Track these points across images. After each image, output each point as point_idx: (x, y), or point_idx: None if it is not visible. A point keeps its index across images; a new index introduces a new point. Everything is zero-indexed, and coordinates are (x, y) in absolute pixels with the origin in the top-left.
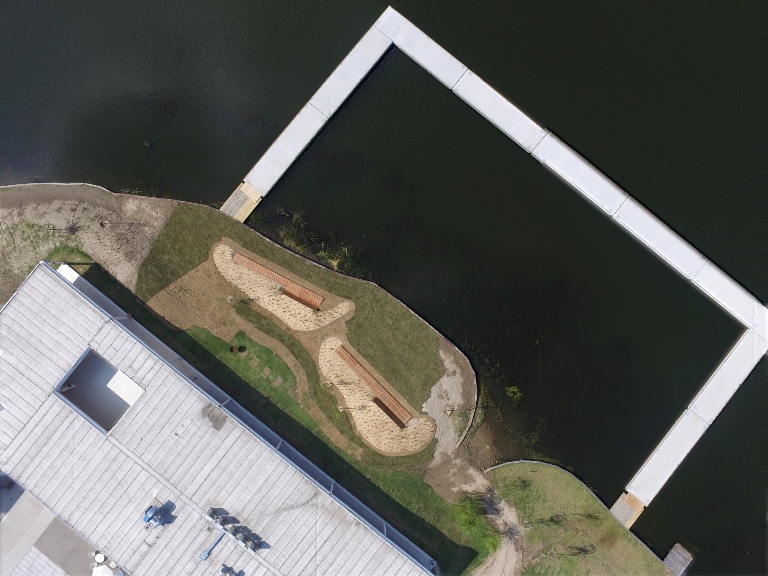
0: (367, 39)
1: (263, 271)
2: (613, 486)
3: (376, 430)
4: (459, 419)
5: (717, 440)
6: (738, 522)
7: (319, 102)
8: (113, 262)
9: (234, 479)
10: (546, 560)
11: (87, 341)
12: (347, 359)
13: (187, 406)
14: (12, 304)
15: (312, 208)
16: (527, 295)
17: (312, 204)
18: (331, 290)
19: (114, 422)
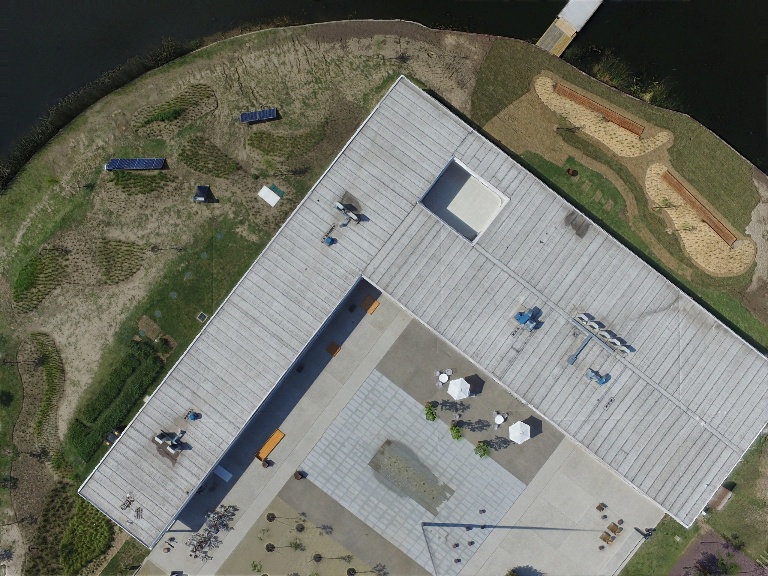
0: None
1: (585, 101)
2: None
3: (707, 250)
4: None
5: None
6: None
7: None
8: (446, 89)
9: (599, 285)
10: None
11: (451, 152)
12: (673, 183)
13: (551, 214)
14: (375, 117)
15: (623, 44)
16: None
17: (622, 40)
18: (649, 120)
19: (469, 236)
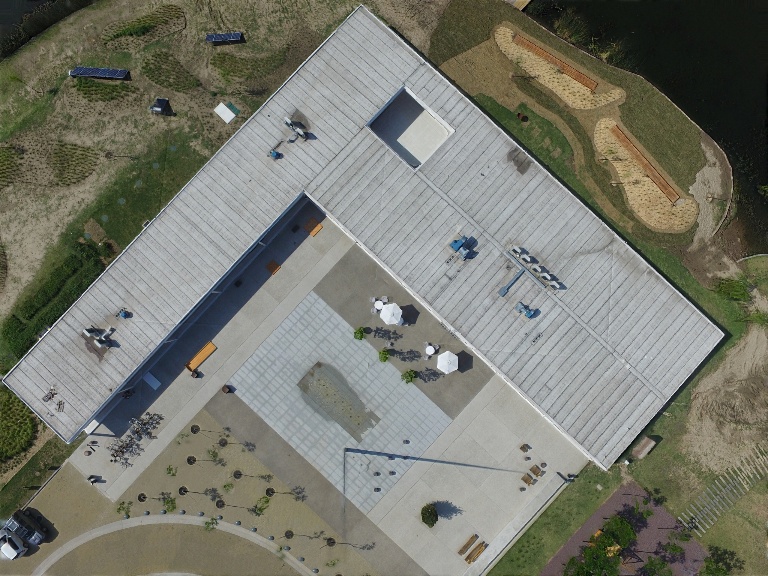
0: None
1: (542, 53)
2: None
3: (649, 204)
4: (717, 208)
5: None
6: None
7: None
8: (407, 28)
9: (535, 221)
10: None
11: (402, 81)
12: (621, 138)
13: (494, 149)
14: (331, 41)
15: (584, 5)
16: None
17: (584, 1)
18: (603, 77)
19: None
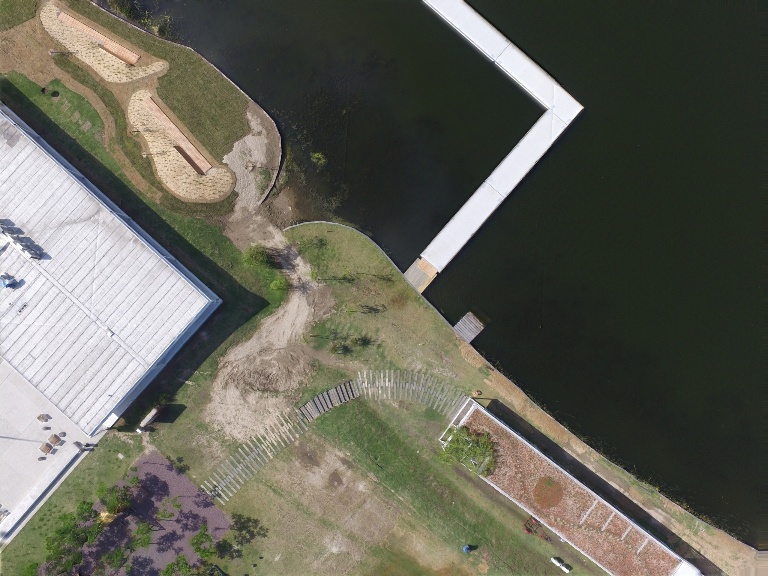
0: None
1: (85, 29)
2: (409, 253)
3: (175, 174)
4: (261, 177)
5: (514, 216)
6: (531, 296)
7: None
8: None
9: (22, 193)
10: (337, 316)
11: None
12: (154, 110)
13: None
14: None
15: None
16: (337, 69)
17: None
18: (148, 50)
19: None
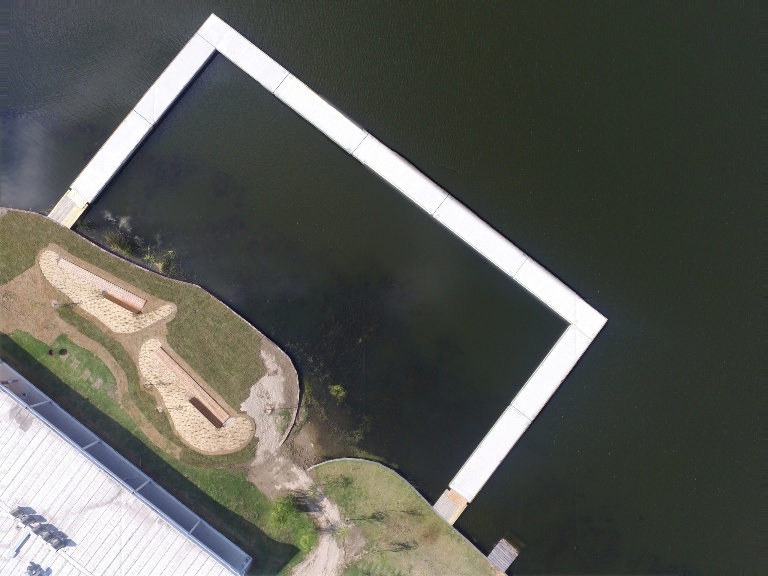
0: (190, 47)
1: (87, 275)
2: (437, 483)
3: (193, 429)
4: (280, 418)
5: (542, 436)
6: (565, 517)
7: (142, 109)
8: None
9: (41, 479)
10: (368, 556)
11: None
12: (166, 360)
13: None
14: None
15: (138, 213)
16: (350, 295)
17: (138, 209)
18: (154, 293)
19: None
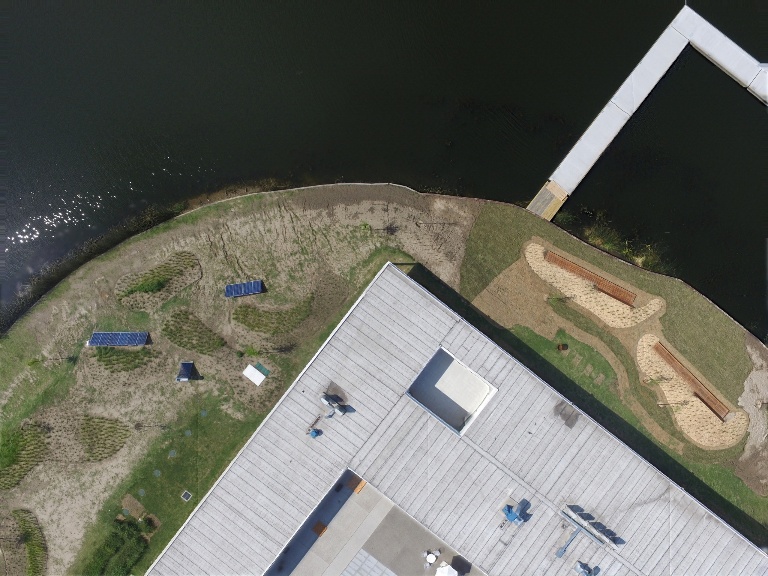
0: (664, 38)
1: (576, 269)
2: None
3: (699, 425)
4: (767, 412)
5: None
6: None
7: (622, 100)
8: (435, 262)
9: (588, 476)
10: None
11: (438, 341)
12: (665, 355)
13: (539, 404)
14: (361, 305)
15: (615, 206)
16: None
17: (614, 202)
18: (641, 287)
19: (457, 422)
